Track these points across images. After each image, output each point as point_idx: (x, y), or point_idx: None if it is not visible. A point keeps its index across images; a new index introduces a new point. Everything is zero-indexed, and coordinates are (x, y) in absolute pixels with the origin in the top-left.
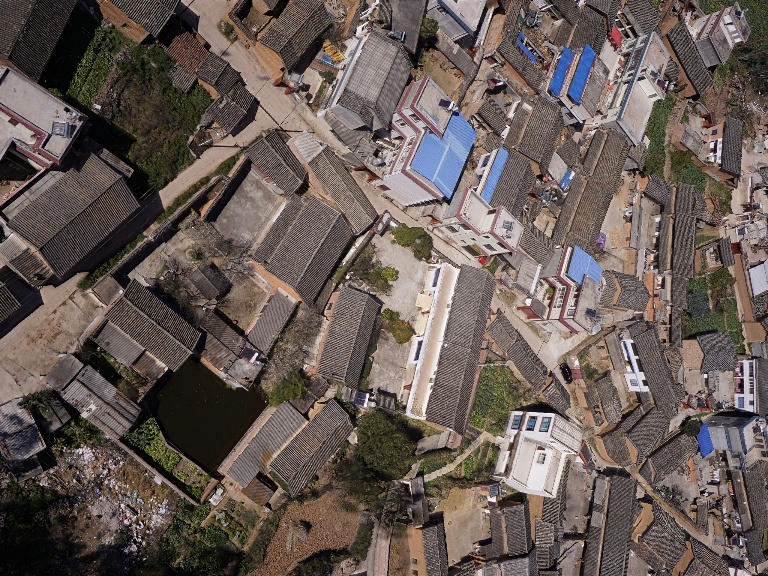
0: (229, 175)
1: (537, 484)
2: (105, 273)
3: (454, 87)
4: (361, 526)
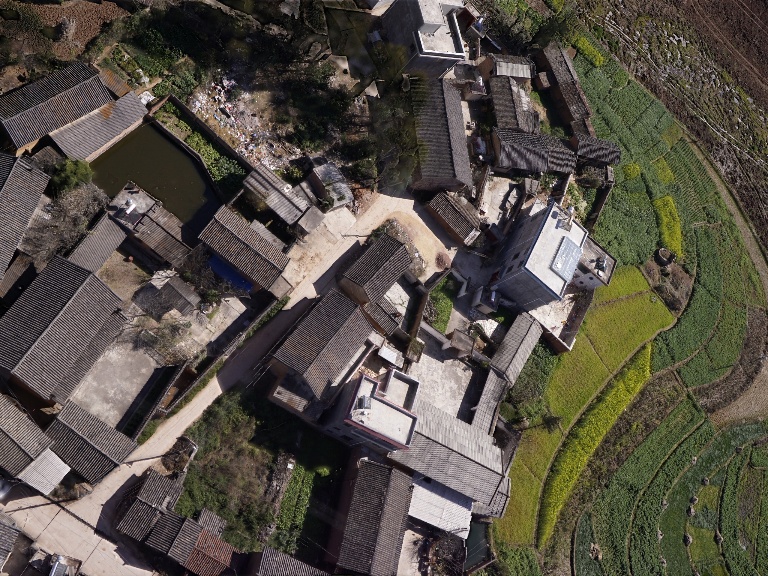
0: None
1: None
2: (272, 307)
3: None
4: None
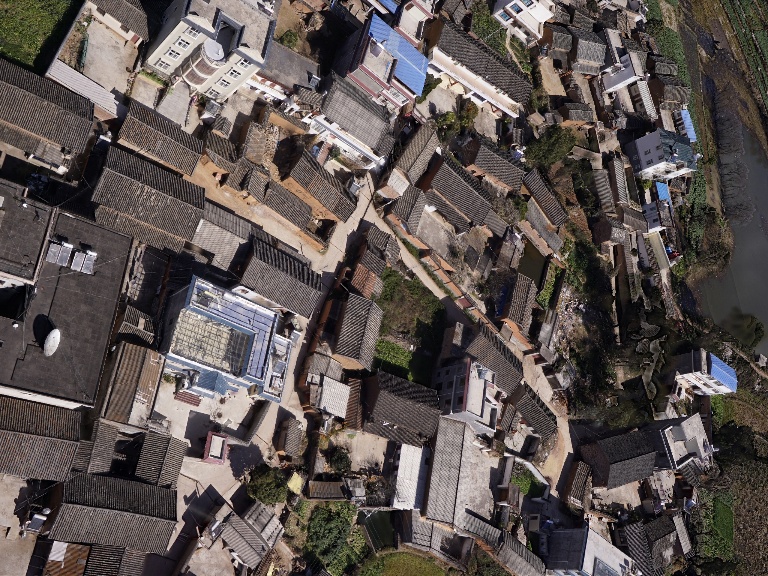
0: (421, 248)
1: (546, 16)
2: None
3: (286, 3)
4: (564, 163)
